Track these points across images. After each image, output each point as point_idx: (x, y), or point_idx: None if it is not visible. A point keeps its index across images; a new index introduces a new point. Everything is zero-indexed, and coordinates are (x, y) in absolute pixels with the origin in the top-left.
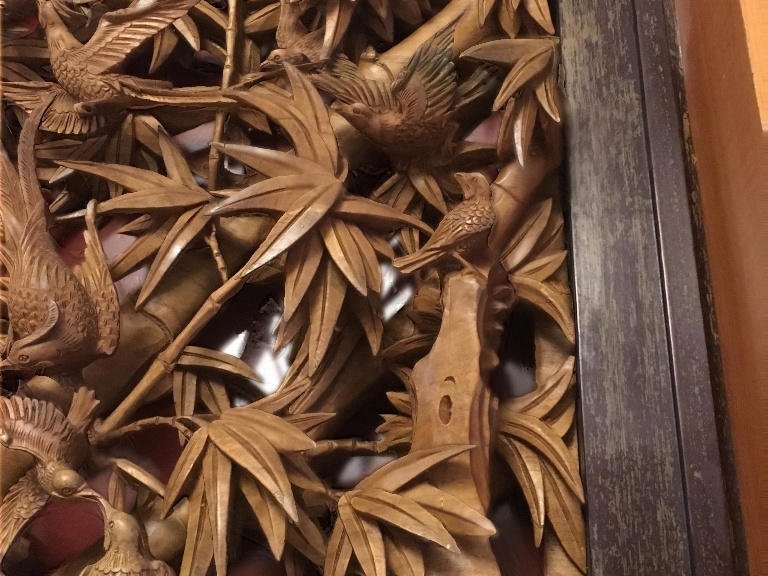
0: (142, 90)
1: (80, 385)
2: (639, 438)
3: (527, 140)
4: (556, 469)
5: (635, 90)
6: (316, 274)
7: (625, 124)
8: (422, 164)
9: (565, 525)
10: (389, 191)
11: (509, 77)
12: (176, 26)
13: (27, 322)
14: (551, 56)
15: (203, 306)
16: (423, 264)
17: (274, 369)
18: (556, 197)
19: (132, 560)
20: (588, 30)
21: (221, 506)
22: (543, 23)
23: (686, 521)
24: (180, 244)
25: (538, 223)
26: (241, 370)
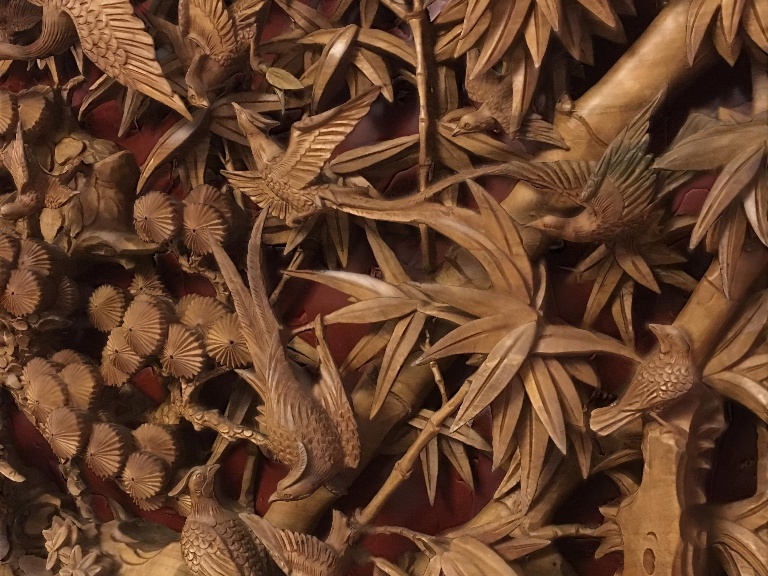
0: (341, 204)
1: (338, 482)
2: None
3: (734, 264)
4: None
5: None
6: (520, 416)
7: None
8: (628, 244)
9: None
10: (597, 265)
11: (709, 199)
12: (367, 75)
13: (285, 456)
14: (763, 155)
15: (425, 428)
16: (619, 426)
17: None
18: None
19: None
20: None
21: None
22: None
23: None
24: (398, 361)
25: (757, 318)
26: (473, 441)
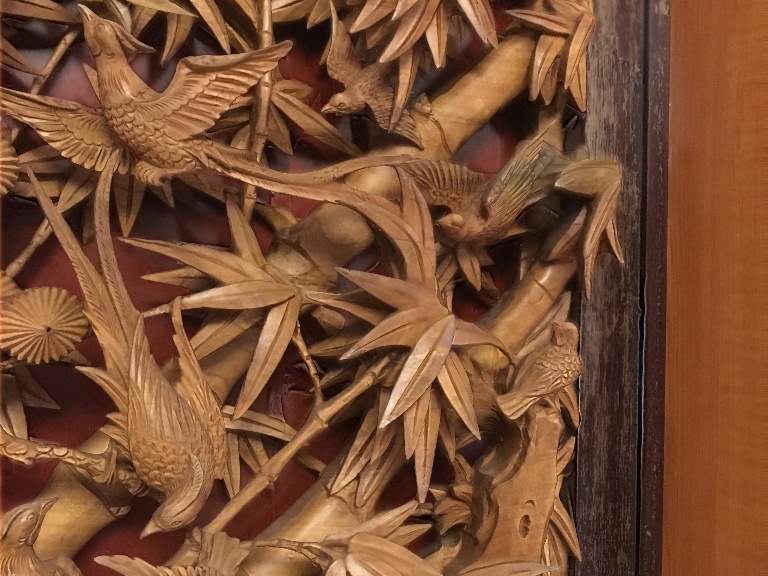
0: (233, 168)
1: None
2: (612, 503)
3: None
4: (560, 533)
5: (637, 184)
6: None
7: (627, 218)
8: (471, 246)
9: None
10: None
11: (596, 219)
12: (202, 14)
13: (161, 474)
14: None
15: (311, 426)
16: (525, 410)
17: None
18: (574, 290)
19: None
20: (608, 109)
21: None
22: (579, 101)
23: (636, 564)
24: (278, 353)
25: (560, 316)
26: (291, 437)
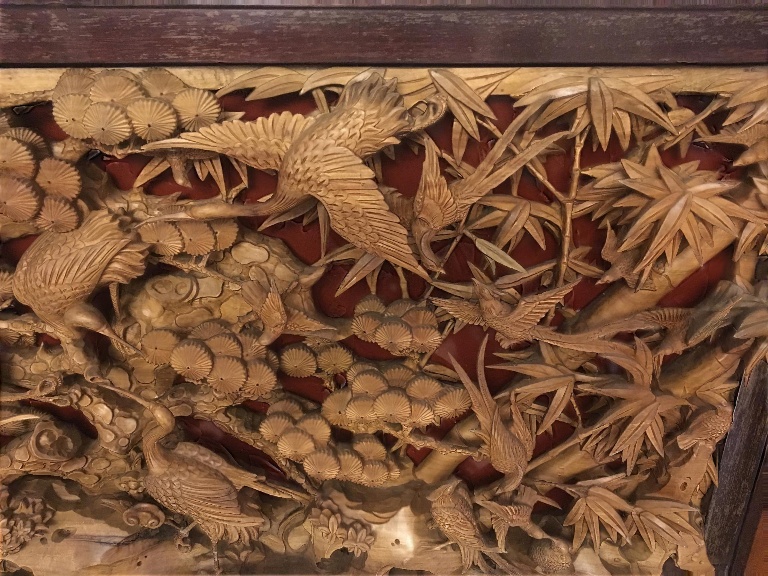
0: None
1: None
2: (744, 459)
3: None
4: None
5: None
6: None
7: None
8: None
9: (704, 485)
10: (653, 342)
11: (758, 354)
12: (531, 233)
13: (504, 470)
14: None
15: (575, 440)
16: (692, 445)
17: None
18: None
19: (568, 558)
20: None
21: (597, 533)
22: None
23: (753, 488)
24: (561, 410)
25: (730, 371)
26: (563, 419)
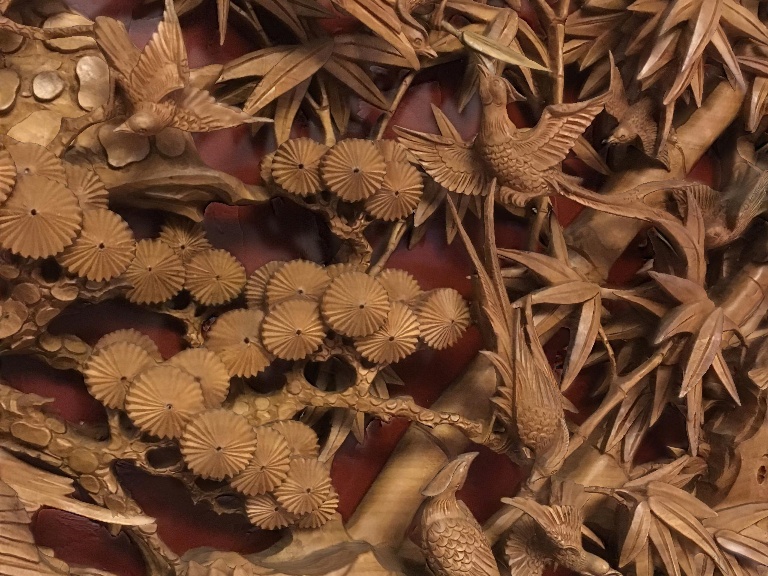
0: (573, 192)
1: None
2: None
3: None
4: None
5: None
6: None
7: None
8: None
9: None
10: None
11: None
12: None
13: (538, 434)
14: None
15: (616, 396)
16: None
17: (583, 402)
18: None
19: None
20: None
21: (676, 564)
22: None
23: None
24: (593, 339)
25: (763, 306)
26: (568, 406)
